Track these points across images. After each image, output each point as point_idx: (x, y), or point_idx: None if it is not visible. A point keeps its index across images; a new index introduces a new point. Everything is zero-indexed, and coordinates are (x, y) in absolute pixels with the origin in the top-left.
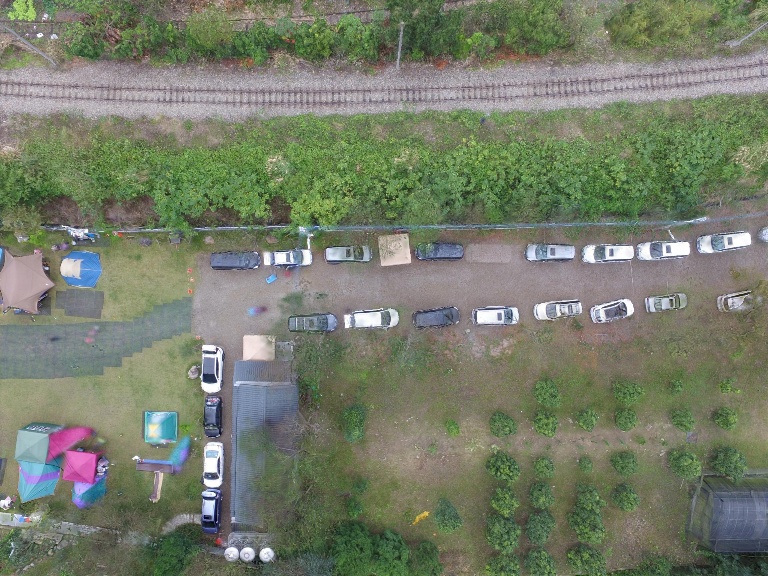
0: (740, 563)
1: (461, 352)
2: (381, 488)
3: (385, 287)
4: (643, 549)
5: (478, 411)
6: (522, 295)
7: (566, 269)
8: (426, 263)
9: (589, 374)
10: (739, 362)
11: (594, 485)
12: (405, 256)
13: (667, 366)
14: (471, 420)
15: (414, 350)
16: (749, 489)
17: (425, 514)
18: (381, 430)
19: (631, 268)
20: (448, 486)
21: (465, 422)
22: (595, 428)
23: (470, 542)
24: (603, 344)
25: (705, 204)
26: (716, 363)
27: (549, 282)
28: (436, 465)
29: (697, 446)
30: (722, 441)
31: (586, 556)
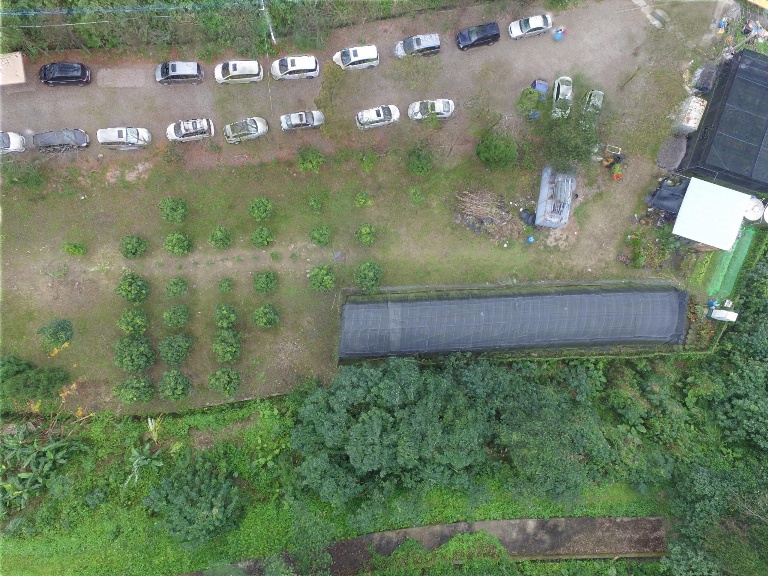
0: (365, 367)
1: (95, 178)
2: (16, 320)
3: (13, 114)
4: (298, 373)
5: (116, 238)
6: (157, 119)
7: (202, 92)
8: (56, 89)
9: (231, 197)
10: (384, 181)
11: (241, 309)
12: (15, 74)
13: (311, 187)
14: (109, 247)
15: (18, 164)
16: (384, 299)
17: (64, 345)
18: (12, 259)
19: (269, 89)
20: (88, 315)
21: (103, 249)
22: (236, 249)
23: (113, 372)
24: (244, 166)
25: (337, 22)
26: (361, 182)
27: (185, 105)
28: (73, 294)
29: (346, 266)
30: (371, 260)
31: (217, 372)
